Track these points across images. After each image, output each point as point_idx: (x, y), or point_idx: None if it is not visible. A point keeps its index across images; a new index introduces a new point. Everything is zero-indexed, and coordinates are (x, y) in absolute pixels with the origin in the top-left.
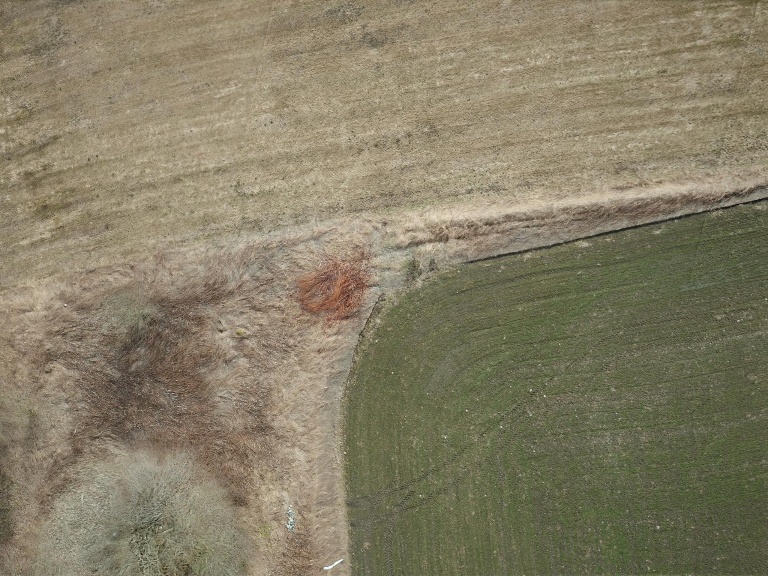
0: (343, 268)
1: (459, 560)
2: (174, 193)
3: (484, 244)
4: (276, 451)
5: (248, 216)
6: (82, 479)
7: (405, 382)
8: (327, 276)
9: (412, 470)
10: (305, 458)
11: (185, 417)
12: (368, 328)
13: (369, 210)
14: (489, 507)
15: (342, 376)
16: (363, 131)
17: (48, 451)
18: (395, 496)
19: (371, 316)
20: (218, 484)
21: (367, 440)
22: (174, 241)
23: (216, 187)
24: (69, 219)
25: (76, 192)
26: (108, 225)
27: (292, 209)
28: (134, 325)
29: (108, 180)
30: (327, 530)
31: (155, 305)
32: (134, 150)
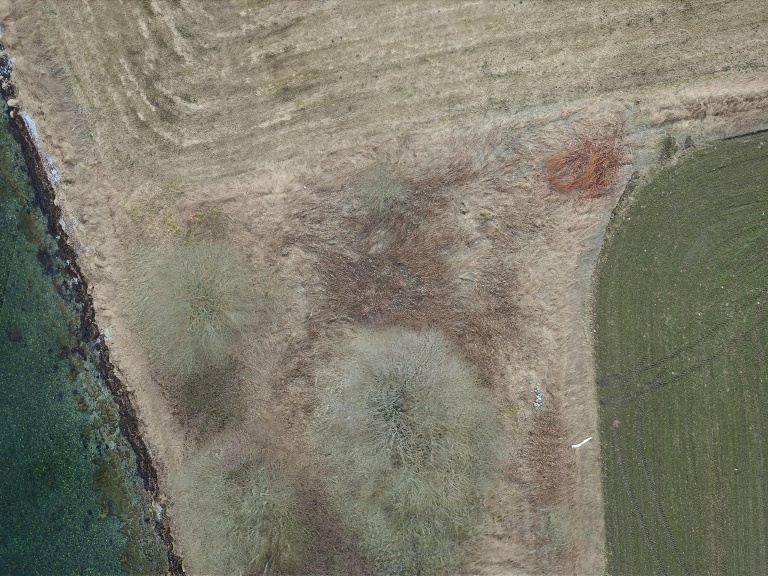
0: (595, 146)
1: (712, 437)
2: (420, 74)
3: (743, 120)
4: (523, 330)
5: (495, 97)
6: (316, 363)
7: (658, 259)
8: (579, 154)
9: (664, 347)
10: (554, 336)
11: (424, 300)
12: (621, 206)
13: (620, 89)
14: (745, 383)
15: (593, 254)
16: (615, 10)
17: (283, 335)
18: (646, 374)
19: (624, 194)
20: (458, 366)
21: (618, 318)
22: (418, 122)
23: (463, 68)
24: (310, 101)
25: (318, 74)
26: (351, 107)
27: (540, 89)
28: (375, 207)
29: (352, 62)
30: (576, 408)
31: (397, 187)
32: (380, 31)
